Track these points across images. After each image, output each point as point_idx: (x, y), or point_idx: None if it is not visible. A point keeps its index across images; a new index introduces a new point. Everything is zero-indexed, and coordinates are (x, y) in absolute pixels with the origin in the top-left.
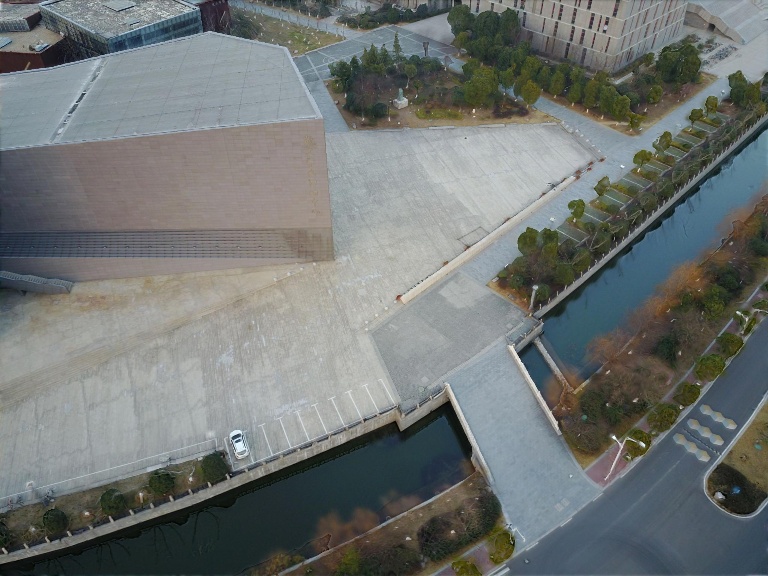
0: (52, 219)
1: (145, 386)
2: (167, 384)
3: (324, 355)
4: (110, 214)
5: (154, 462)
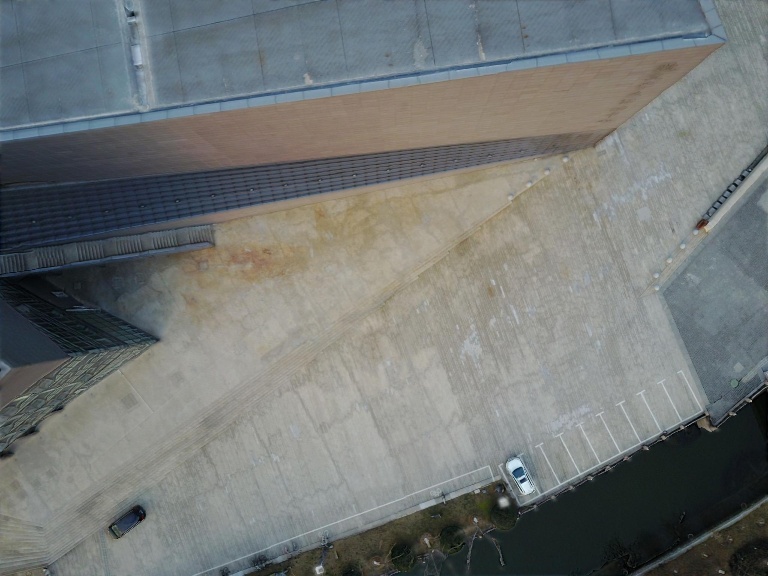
0: (158, 166)
1: (379, 395)
2: (406, 391)
3: (602, 336)
4: (254, 155)
5: (425, 498)
